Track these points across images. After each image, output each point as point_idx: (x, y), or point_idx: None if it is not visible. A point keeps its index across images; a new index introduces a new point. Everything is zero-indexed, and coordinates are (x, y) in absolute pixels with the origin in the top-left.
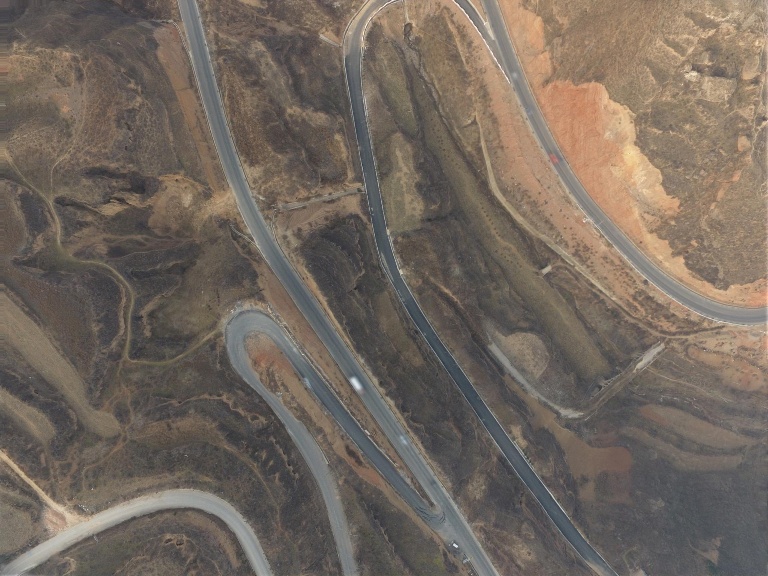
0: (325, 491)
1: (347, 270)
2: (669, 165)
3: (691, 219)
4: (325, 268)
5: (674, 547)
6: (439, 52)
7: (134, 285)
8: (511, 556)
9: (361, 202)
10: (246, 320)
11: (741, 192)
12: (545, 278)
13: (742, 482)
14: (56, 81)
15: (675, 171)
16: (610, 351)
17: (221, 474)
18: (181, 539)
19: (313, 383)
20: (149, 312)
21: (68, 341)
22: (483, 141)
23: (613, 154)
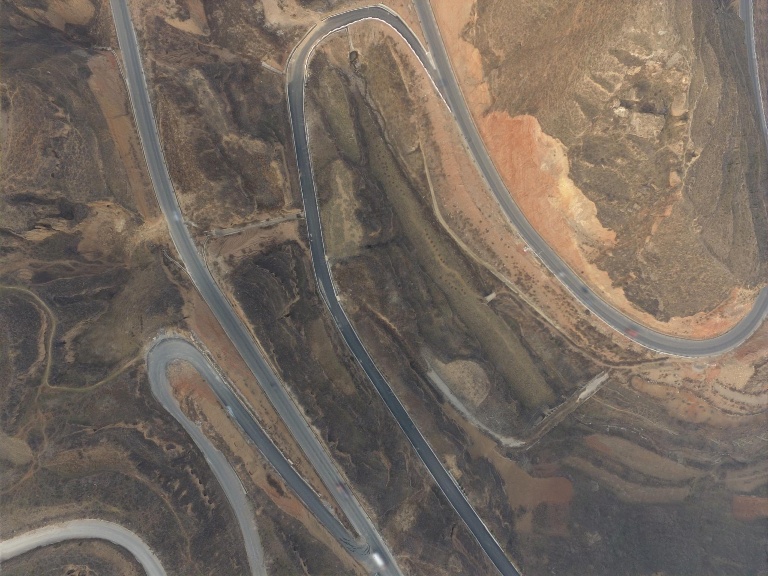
0: (242, 521)
1: (278, 297)
2: (603, 198)
3: (628, 251)
4: (254, 295)
5: None
6: (383, 80)
7: (56, 311)
8: None
9: (299, 228)
10: (168, 348)
11: (674, 227)
12: (489, 305)
13: (687, 515)
14: None
15: (609, 204)
16: (555, 379)
17: (130, 504)
18: (84, 570)
19: (236, 411)
20: (74, 337)
21: None
22: (427, 168)
23: (550, 185)
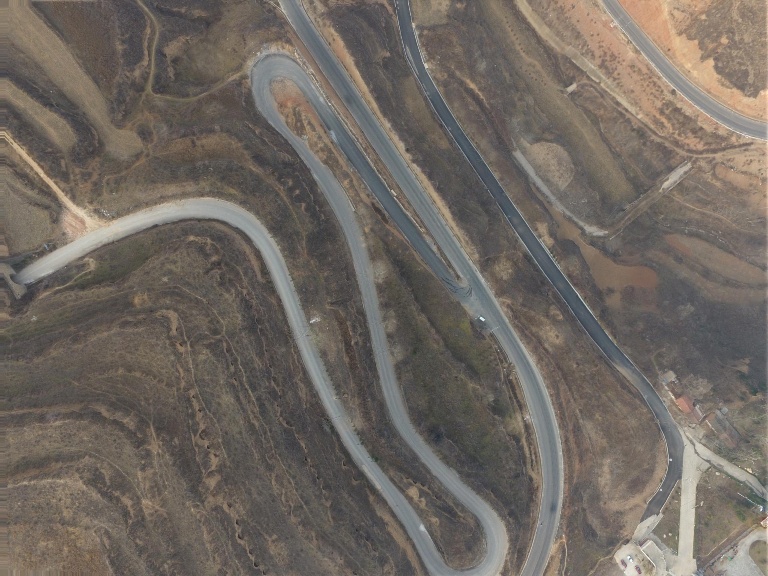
0: (351, 238)
1: (374, 42)
2: None
3: (722, 10)
4: (352, 31)
5: None
6: None
7: (159, 17)
8: (538, 338)
9: None
10: (272, 64)
11: None
12: (570, 97)
13: None
14: None
15: None
16: (635, 177)
17: (247, 190)
18: (205, 242)
19: (339, 137)
20: (173, 58)
21: (91, 59)
22: None
23: None
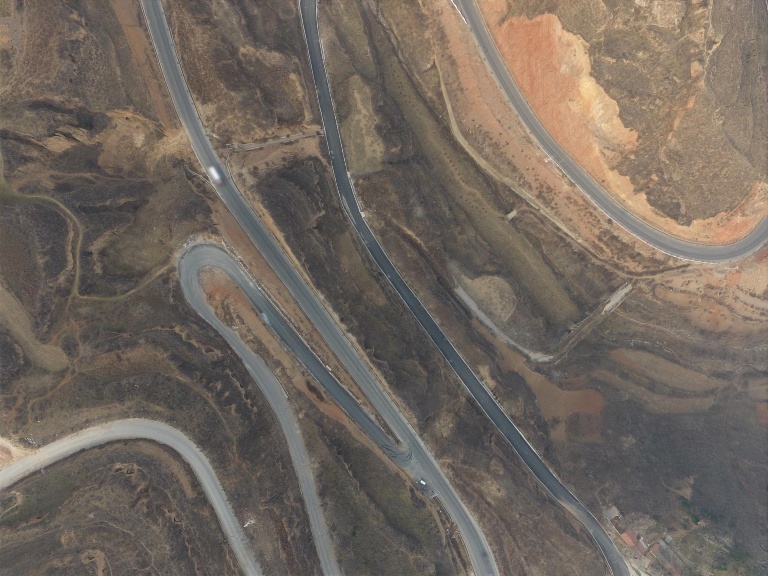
0: (285, 426)
1: (305, 208)
2: (625, 95)
3: (650, 152)
4: (282, 204)
5: (647, 486)
6: None
7: (82, 219)
8: (480, 493)
9: (320, 144)
10: (200, 254)
11: (696, 119)
12: (511, 223)
13: (714, 422)
14: None
15: (631, 101)
16: (579, 296)
17: (173, 404)
18: (132, 468)
19: (271, 318)
20: (100, 250)
21: (12, 274)
22: (443, 85)
23: (570, 88)
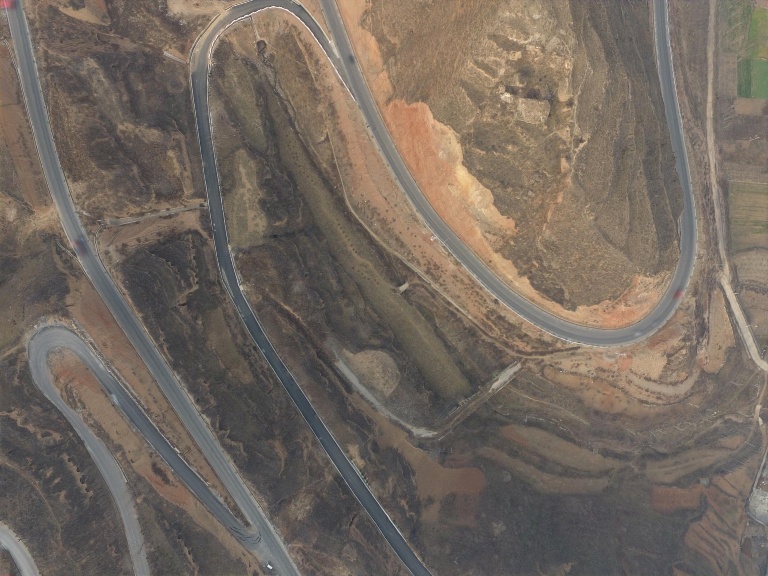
0: (123, 509)
1: (172, 286)
2: (498, 185)
3: (528, 239)
4: (144, 284)
5: (522, 572)
6: (290, 69)
7: None
8: None
9: (200, 218)
10: (50, 336)
11: (566, 214)
12: (403, 295)
13: (602, 506)
14: None
15: (505, 191)
16: (471, 370)
17: None
18: None
19: (121, 400)
20: None
21: None
22: (335, 158)
23: (448, 173)
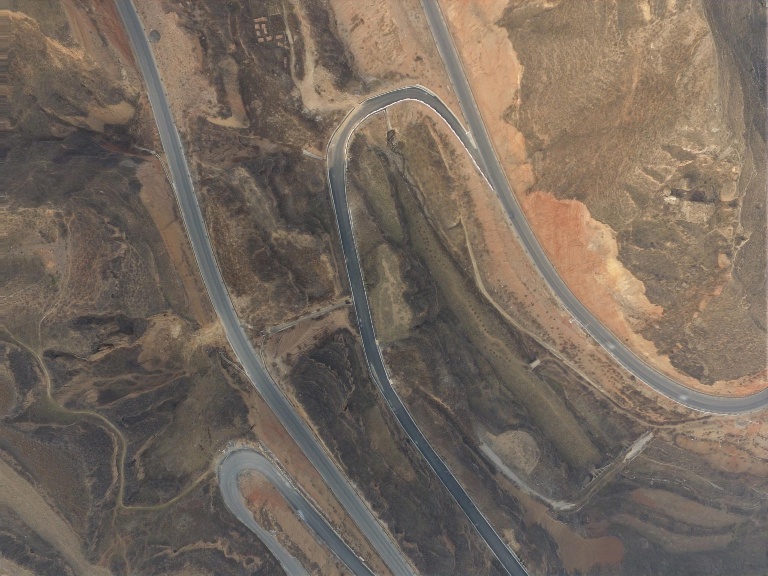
0: None
1: (337, 393)
2: (652, 278)
3: (675, 324)
4: (315, 395)
5: None
6: (422, 158)
7: (126, 433)
8: None
9: (349, 316)
10: (238, 459)
11: (723, 305)
12: (534, 371)
13: (732, 564)
14: (40, 237)
15: (658, 283)
16: (600, 438)
17: None
18: None
19: (306, 515)
20: (142, 452)
21: (62, 497)
22: (469, 243)
23: (597, 264)
